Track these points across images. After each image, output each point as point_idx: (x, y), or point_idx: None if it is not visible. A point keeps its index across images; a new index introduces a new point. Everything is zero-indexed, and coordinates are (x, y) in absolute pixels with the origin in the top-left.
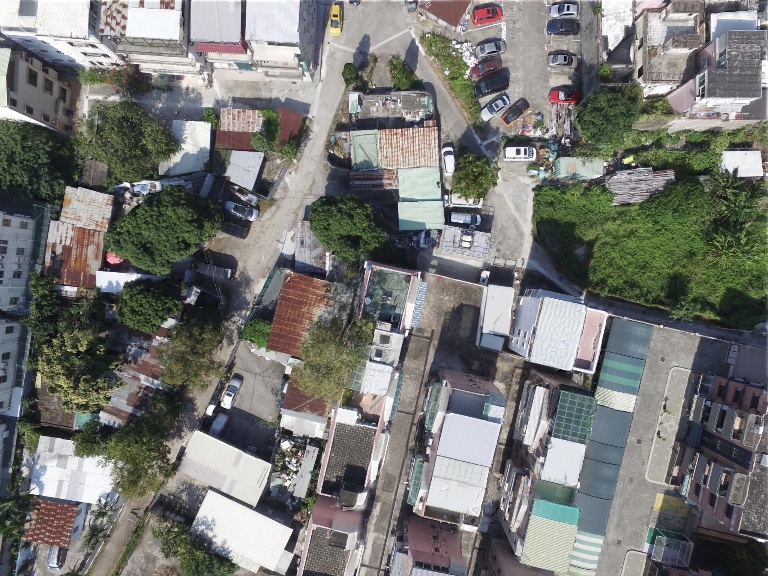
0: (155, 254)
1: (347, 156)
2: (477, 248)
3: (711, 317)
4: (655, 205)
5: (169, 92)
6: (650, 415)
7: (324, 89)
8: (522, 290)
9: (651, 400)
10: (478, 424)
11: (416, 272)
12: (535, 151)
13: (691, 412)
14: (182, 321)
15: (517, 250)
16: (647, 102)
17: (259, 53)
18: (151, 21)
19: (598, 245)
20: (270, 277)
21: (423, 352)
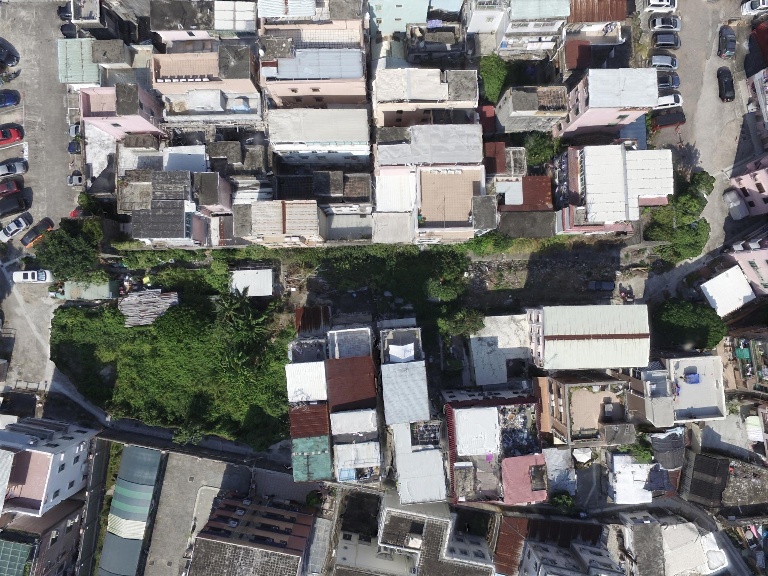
0: None
1: None
2: None
3: (226, 438)
4: (157, 329)
5: None
6: (180, 536)
7: None
8: (45, 413)
9: (180, 521)
10: None
11: None
12: (49, 273)
13: None
14: None
15: (39, 373)
16: None
17: None
18: None
19: (120, 366)
20: None
21: None
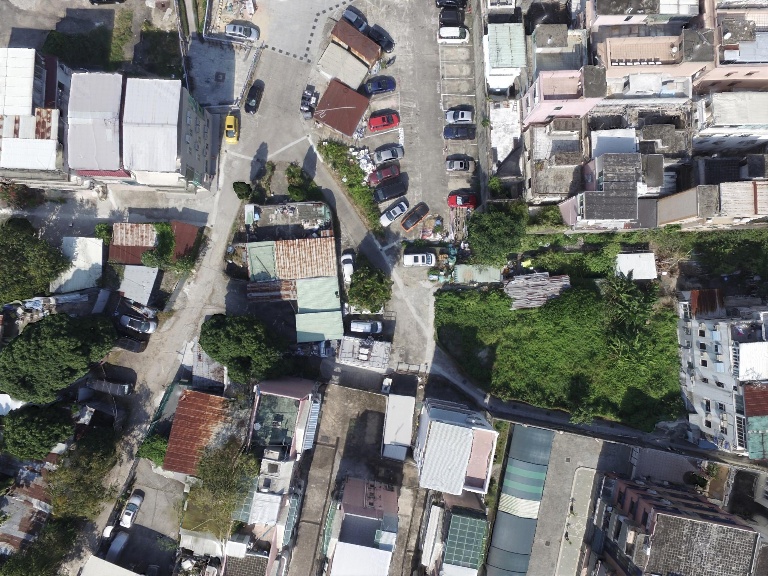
0: (35, 386)
1: (246, 265)
2: (376, 358)
3: (612, 419)
4: (551, 311)
5: (63, 204)
6: (558, 516)
7: (222, 198)
8: (426, 395)
9: (558, 501)
10: (368, 553)
11: (306, 395)
12: (434, 257)
13: (595, 516)
14: (73, 445)
15: (420, 355)
16: (540, 209)
17: (142, 178)
18: (26, 152)
19: (500, 348)
20: (168, 392)
21: (329, 460)
